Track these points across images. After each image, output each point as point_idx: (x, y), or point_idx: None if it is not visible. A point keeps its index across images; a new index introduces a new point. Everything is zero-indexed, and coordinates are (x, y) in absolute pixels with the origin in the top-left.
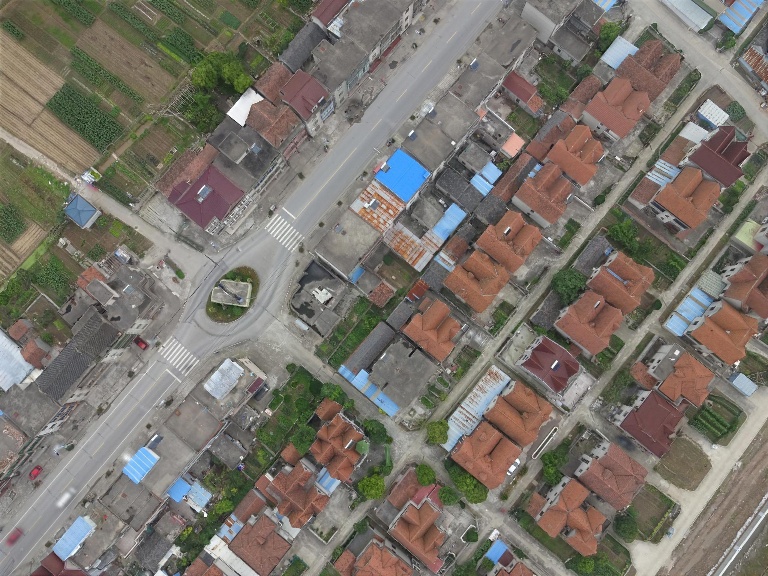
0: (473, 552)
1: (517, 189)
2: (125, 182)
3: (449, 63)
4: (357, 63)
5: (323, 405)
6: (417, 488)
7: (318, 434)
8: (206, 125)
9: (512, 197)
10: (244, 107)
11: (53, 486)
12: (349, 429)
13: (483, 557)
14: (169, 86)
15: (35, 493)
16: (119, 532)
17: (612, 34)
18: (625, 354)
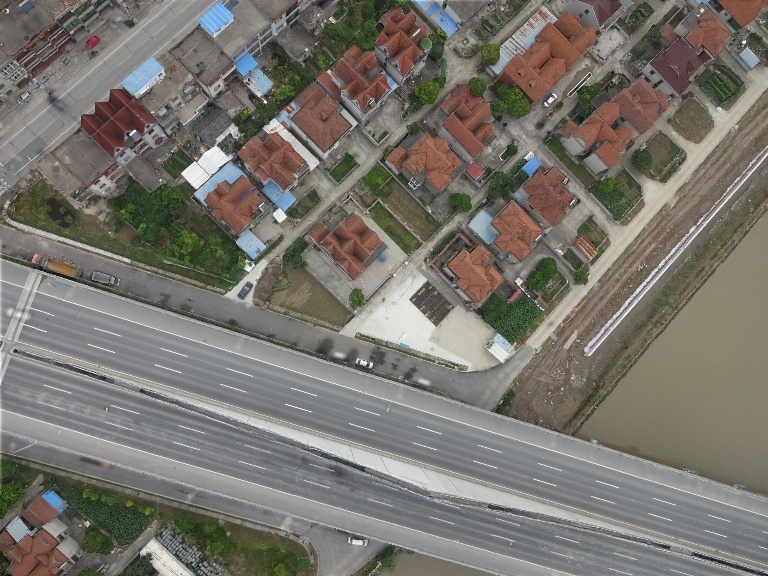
0: (509, 170)
1: None
2: None
3: None
4: None
5: (388, 14)
6: (468, 99)
7: (387, 24)
8: None
9: None
10: None
11: (110, 59)
12: (414, 28)
13: (519, 171)
14: None
15: (90, 63)
16: (188, 84)
17: None
18: (654, 21)
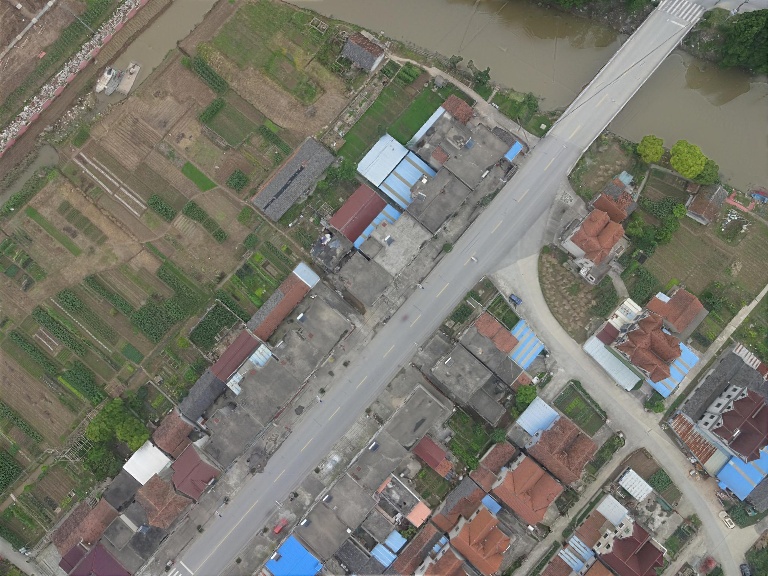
0: None
1: (421, 561)
2: (22, 526)
3: (358, 411)
4: (252, 437)
5: None
6: None
7: None
8: (103, 473)
9: (415, 570)
10: (141, 460)
11: None
12: None
13: None
14: (69, 424)
15: None
16: None
17: (528, 402)
18: None
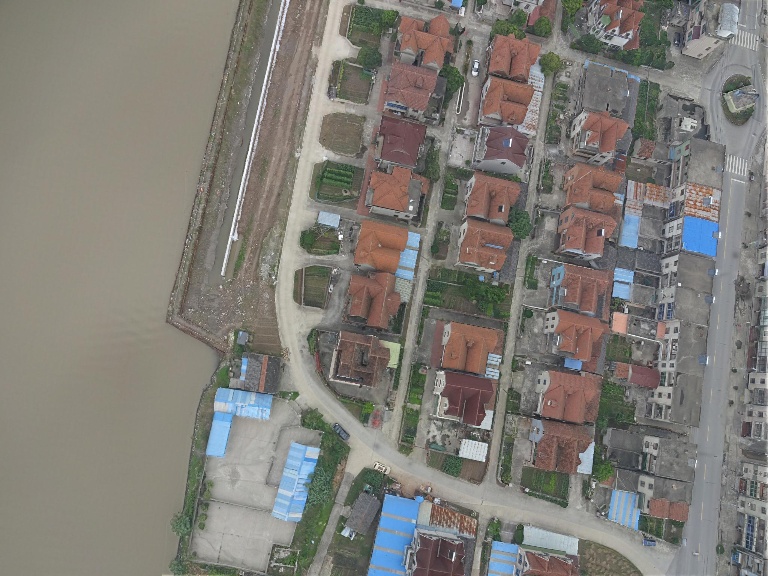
0: None
1: None
2: None
3: None
4: None
5: None
6: None
7: None
8: None
9: None
10: None
11: None
12: None
13: None
14: None
15: None
16: None
17: (603, 466)
18: (435, 199)
